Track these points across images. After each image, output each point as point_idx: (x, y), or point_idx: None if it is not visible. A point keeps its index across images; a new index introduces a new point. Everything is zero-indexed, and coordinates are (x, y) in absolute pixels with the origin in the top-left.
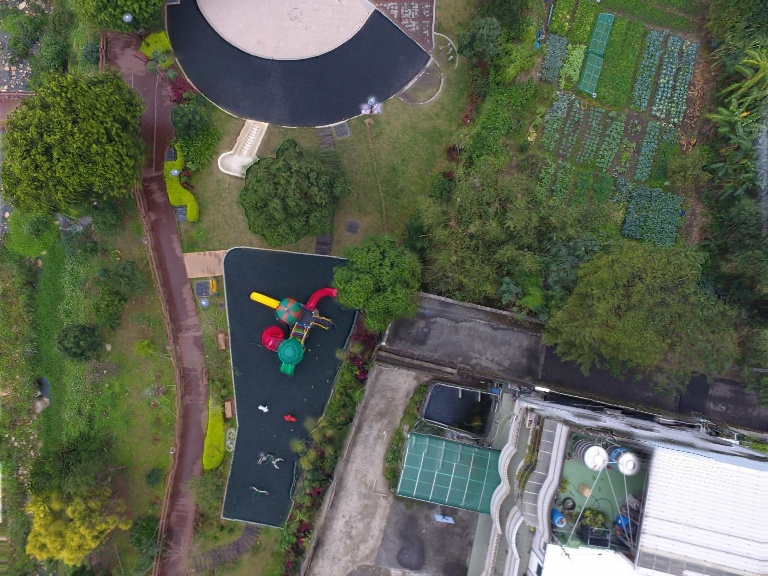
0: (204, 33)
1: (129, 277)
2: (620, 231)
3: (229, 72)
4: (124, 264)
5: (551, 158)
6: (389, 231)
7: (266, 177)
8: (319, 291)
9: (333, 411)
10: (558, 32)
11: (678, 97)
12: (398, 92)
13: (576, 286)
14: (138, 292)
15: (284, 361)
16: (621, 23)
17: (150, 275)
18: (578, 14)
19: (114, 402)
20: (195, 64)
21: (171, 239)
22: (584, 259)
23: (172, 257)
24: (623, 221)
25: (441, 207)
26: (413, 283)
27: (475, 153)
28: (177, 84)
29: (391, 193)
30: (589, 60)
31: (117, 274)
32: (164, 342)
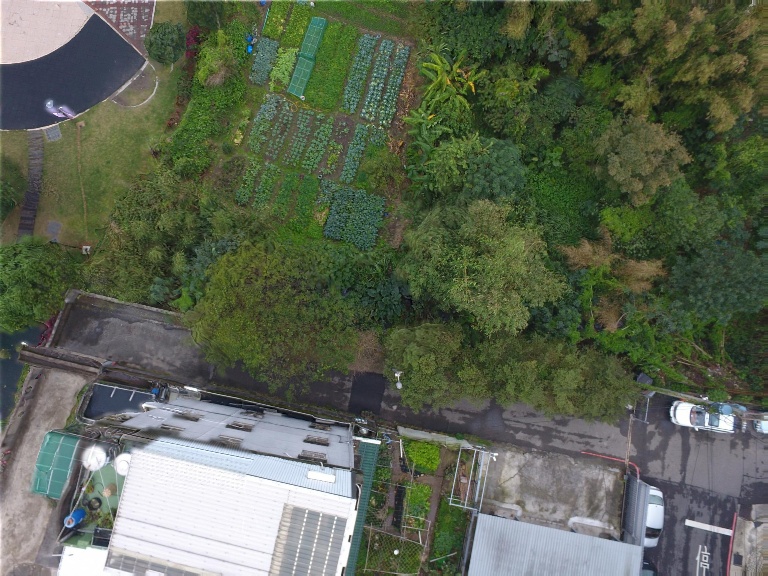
0: None
1: None
2: (322, 232)
3: None
4: None
5: (256, 160)
6: (89, 232)
7: None
8: None
9: None
10: (271, 36)
11: (388, 100)
12: (111, 95)
13: (205, 286)
14: None
15: None
16: (334, 27)
17: None
18: (292, 18)
19: None
20: None
21: None
22: (218, 259)
23: None
24: (325, 222)
25: None
26: None
27: (176, 155)
28: None
29: (93, 195)
30: (298, 63)
31: None
32: None
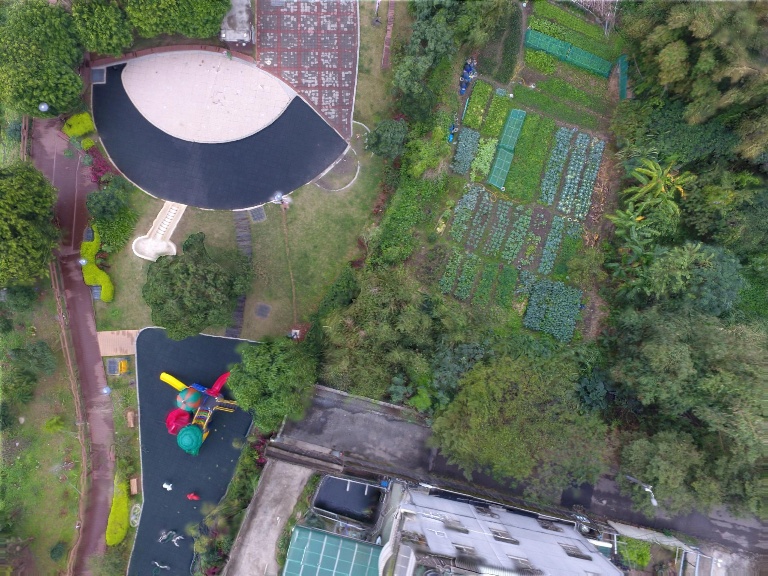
0: (128, 114)
1: (39, 358)
2: (521, 322)
3: (151, 153)
4: (34, 346)
5: (458, 249)
6: (298, 316)
7: (164, 277)
8: (226, 374)
9: (233, 492)
10: (471, 126)
11: (584, 193)
12: (315, 178)
13: (455, 394)
14: (47, 373)
15: (183, 448)
16: (533, 119)
17: (62, 354)
18: (492, 109)
19: (25, 474)
20: (118, 144)
21: (86, 317)
22: (465, 367)
23: (86, 335)
24: (524, 313)
25: (348, 296)
26: (311, 375)
27: (384, 243)
28: (97, 166)
29: (302, 279)
30: (499, 155)
31: (27, 355)
32: (75, 418)
